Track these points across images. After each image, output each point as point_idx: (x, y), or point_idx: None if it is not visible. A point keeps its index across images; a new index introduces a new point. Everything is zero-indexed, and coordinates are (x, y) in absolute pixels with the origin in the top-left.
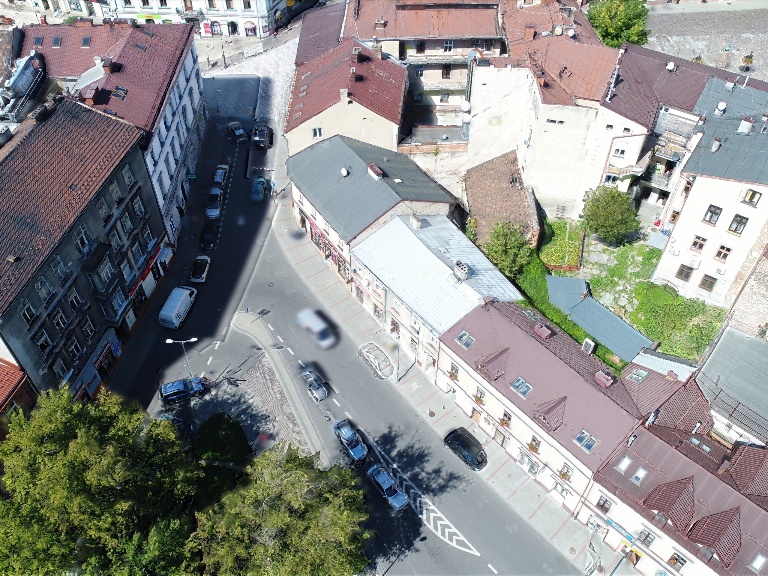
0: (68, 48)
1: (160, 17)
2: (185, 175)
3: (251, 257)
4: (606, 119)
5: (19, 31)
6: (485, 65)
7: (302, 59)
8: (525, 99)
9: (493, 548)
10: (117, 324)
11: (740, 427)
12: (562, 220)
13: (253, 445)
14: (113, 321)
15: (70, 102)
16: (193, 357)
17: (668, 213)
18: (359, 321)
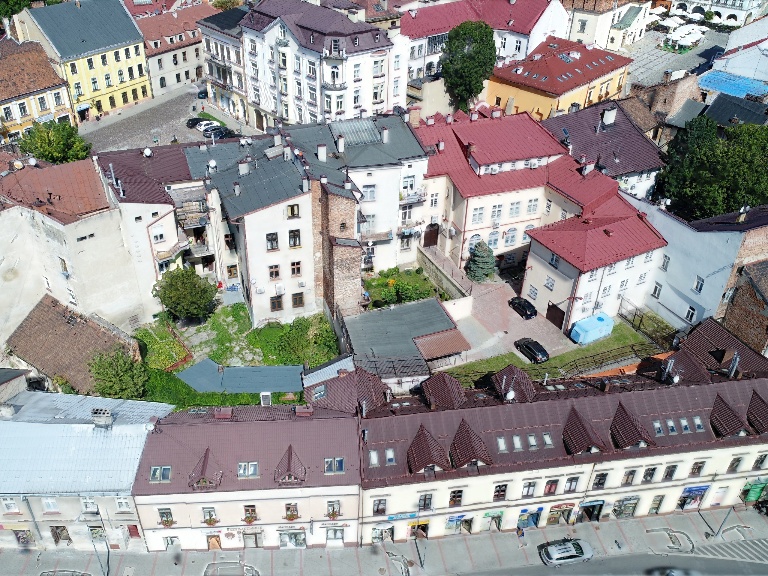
0: None
1: None
2: None
3: None
4: (132, 213)
5: None
6: None
7: None
8: (32, 237)
9: None
10: None
11: (407, 376)
12: (140, 329)
13: None
14: None
15: None
16: None
17: (224, 271)
18: (5, 565)
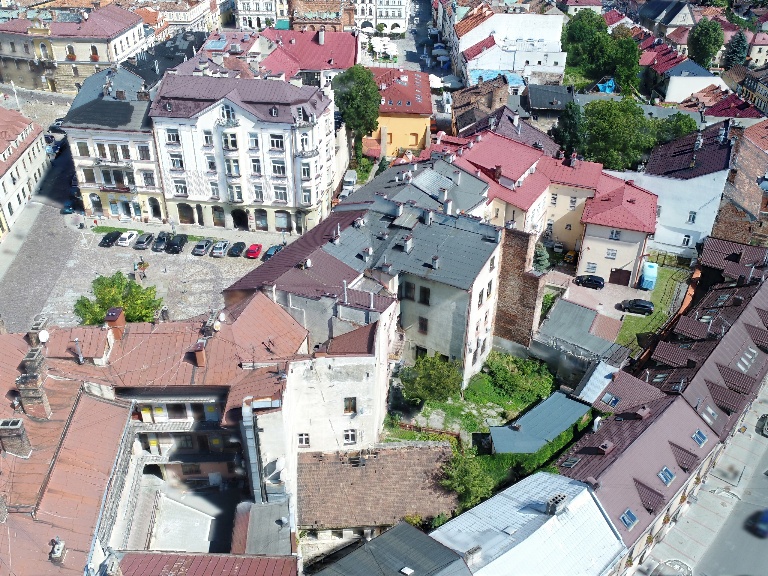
0: None
1: None
2: None
3: None
4: None
5: None
6: (282, 399)
7: None
8: (300, 393)
9: (760, 561)
10: None
11: None
12: None
13: None
14: None
15: None
16: None
17: None
18: None
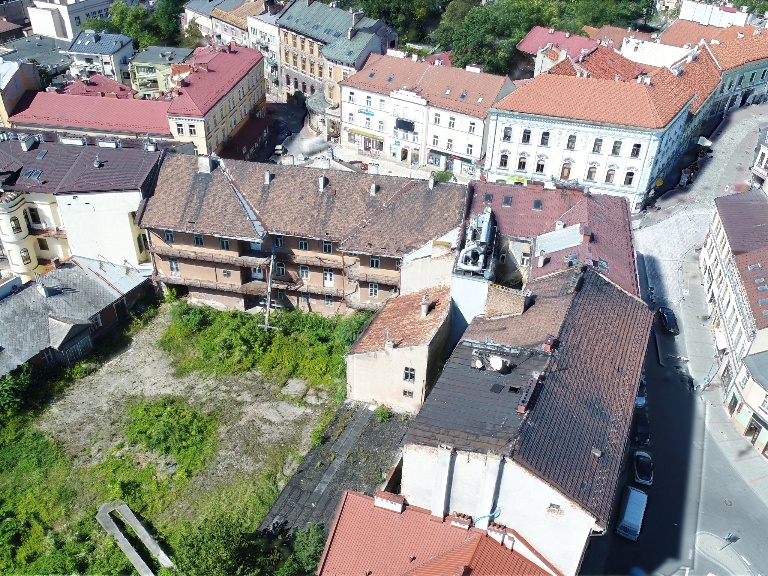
0: (519, 208)
1: None
2: None
3: (694, 462)
4: None
5: (470, 186)
6: None
7: (740, 247)
8: None
9: None
10: None
11: None
12: None
13: None
14: None
15: (592, 272)
16: None
17: None
18: None
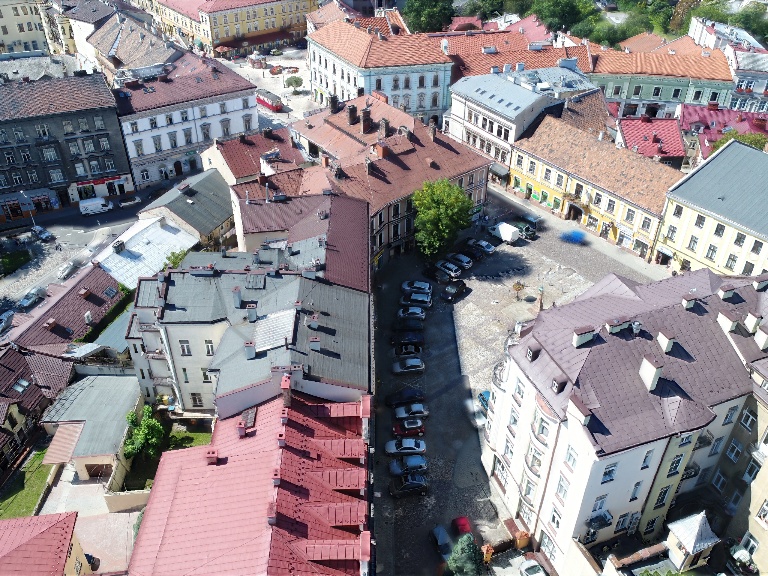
0: None
1: (325, 94)
2: (185, 160)
3: None
4: None
5: (182, 53)
6: None
7: None
8: None
9: None
10: (50, 187)
11: None
12: None
13: (18, 270)
14: (48, 183)
15: (101, 76)
16: (69, 229)
17: None
18: None
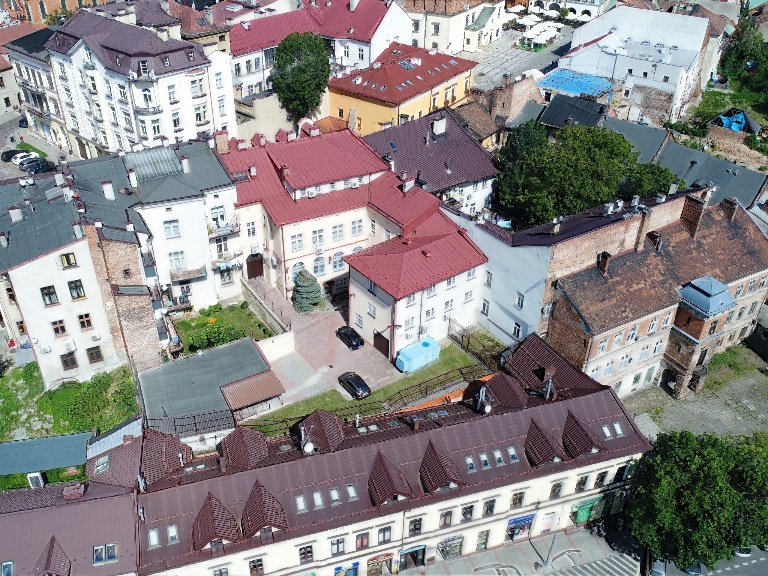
0: None
1: None
2: None
3: None
4: None
5: None
6: None
7: None
8: None
9: None
10: None
11: (209, 432)
12: None
13: None
14: None
15: None
16: None
17: (13, 328)
18: None
